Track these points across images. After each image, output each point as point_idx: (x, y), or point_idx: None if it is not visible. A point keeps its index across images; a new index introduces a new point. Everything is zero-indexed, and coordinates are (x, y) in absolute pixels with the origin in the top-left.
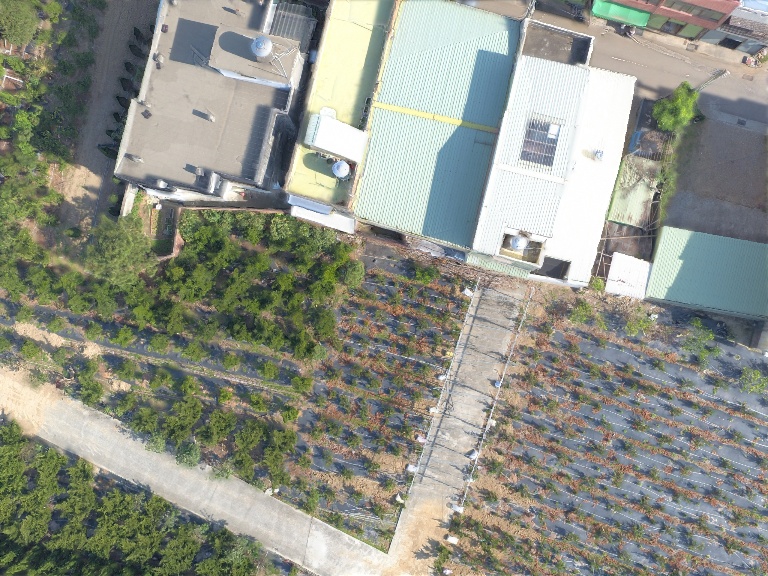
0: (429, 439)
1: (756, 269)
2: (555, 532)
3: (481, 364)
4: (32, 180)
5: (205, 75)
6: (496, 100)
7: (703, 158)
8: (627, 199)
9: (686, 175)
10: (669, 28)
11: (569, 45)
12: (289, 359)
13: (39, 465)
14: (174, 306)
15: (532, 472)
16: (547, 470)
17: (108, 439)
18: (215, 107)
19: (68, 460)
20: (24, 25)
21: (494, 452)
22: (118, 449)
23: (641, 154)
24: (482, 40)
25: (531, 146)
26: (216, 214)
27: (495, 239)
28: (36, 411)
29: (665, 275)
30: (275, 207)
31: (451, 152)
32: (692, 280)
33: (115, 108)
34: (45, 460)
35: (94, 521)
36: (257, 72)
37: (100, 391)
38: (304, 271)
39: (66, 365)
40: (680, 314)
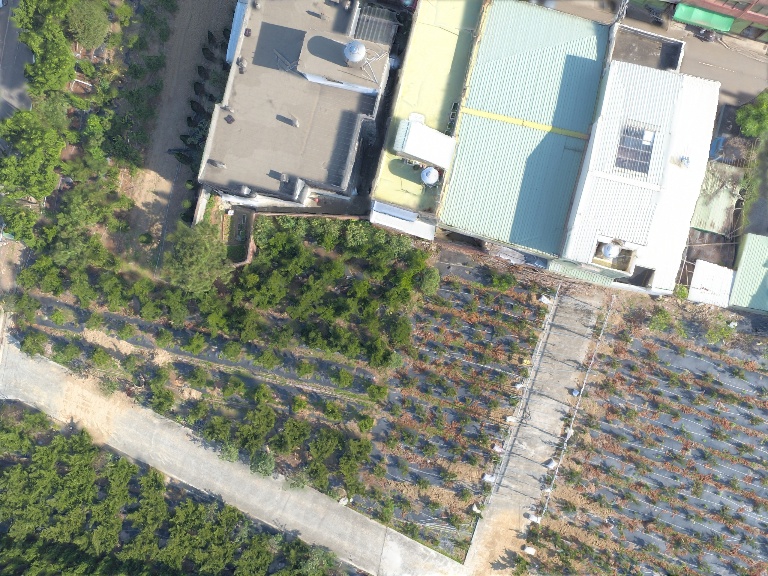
0: None
1: None
2: (634, 543)
3: (558, 372)
4: (103, 185)
5: (289, 80)
6: (586, 106)
7: None
8: (709, 206)
9: (766, 181)
10: (748, 33)
11: (658, 50)
12: (363, 367)
13: (110, 474)
14: (248, 313)
15: (610, 482)
16: (625, 480)
17: (179, 448)
18: (299, 112)
19: (138, 469)
20: (97, 28)
21: (572, 461)
22: (189, 458)
23: (724, 160)
24: (570, 45)
25: (626, 153)
26: (291, 220)
27: (588, 247)
28: (106, 419)
29: (749, 283)
30: (349, 213)
31: (540, 158)
32: None
33: (186, 112)
34: (116, 469)
35: (164, 531)
36: (347, 77)
37: (172, 399)
38: (379, 278)
39: (136, 373)
40: (760, 322)
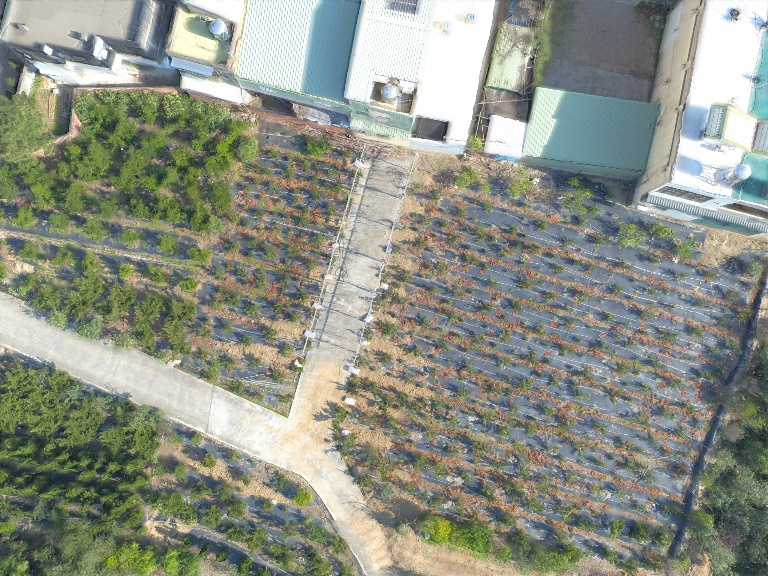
0: (325, 305)
1: (624, 125)
2: (448, 389)
3: (373, 231)
4: None
5: None
6: None
7: (576, 29)
8: (502, 65)
9: (560, 45)
10: None
11: None
12: (188, 235)
13: None
14: (71, 183)
15: (425, 333)
16: (439, 330)
17: (12, 319)
18: None
19: None
20: None
21: (388, 315)
22: (22, 328)
23: (513, 21)
24: None
25: None
26: (110, 93)
27: (364, 86)
28: None
29: (540, 134)
30: None
31: (324, 11)
32: (565, 138)
33: None
34: None
35: None
36: None
37: (2, 270)
38: (198, 147)
39: None
40: (560, 177)
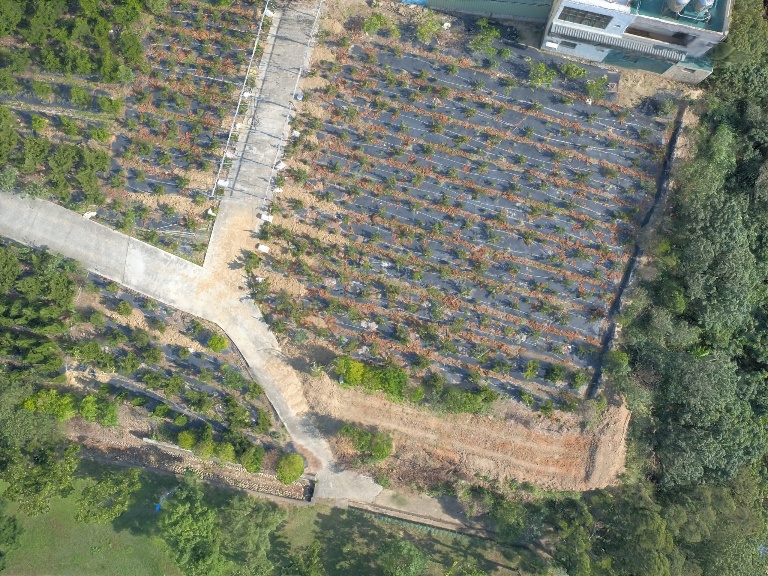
0: (237, 154)
1: None
2: (362, 235)
3: (284, 80)
4: None
5: None
6: None
7: None
8: None
9: None
10: None
11: None
12: (102, 89)
13: None
14: None
15: (337, 180)
16: (351, 177)
17: None
18: None
19: None
20: None
21: (300, 163)
22: None
23: None
24: None
25: None
26: None
27: None
28: None
29: None
30: None
31: None
32: None
33: None
34: None
35: None
36: None
37: None
38: None
39: None
40: (471, 21)
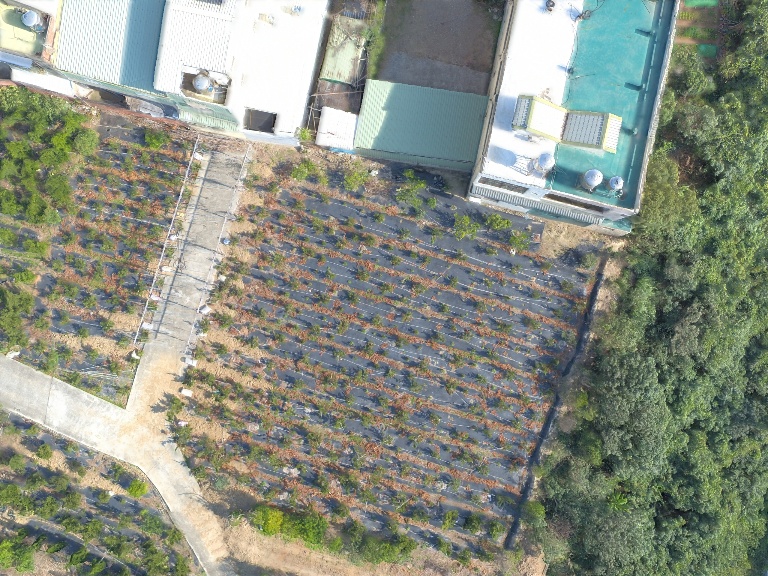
0: (163, 297)
1: (454, 117)
2: (285, 381)
3: (211, 223)
4: None
5: None
6: None
7: (415, 21)
8: (335, 57)
9: (399, 37)
10: None
11: None
12: (28, 227)
13: None
14: None
15: (263, 325)
16: (276, 322)
17: None
18: None
19: None
20: None
21: (225, 307)
22: None
23: (346, 13)
24: None
25: None
26: None
27: (173, 77)
28: None
29: (370, 126)
30: None
31: (140, 3)
32: (396, 130)
33: None
34: None
35: None
36: None
37: None
38: (36, 139)
39: None
40: (399, 169)
